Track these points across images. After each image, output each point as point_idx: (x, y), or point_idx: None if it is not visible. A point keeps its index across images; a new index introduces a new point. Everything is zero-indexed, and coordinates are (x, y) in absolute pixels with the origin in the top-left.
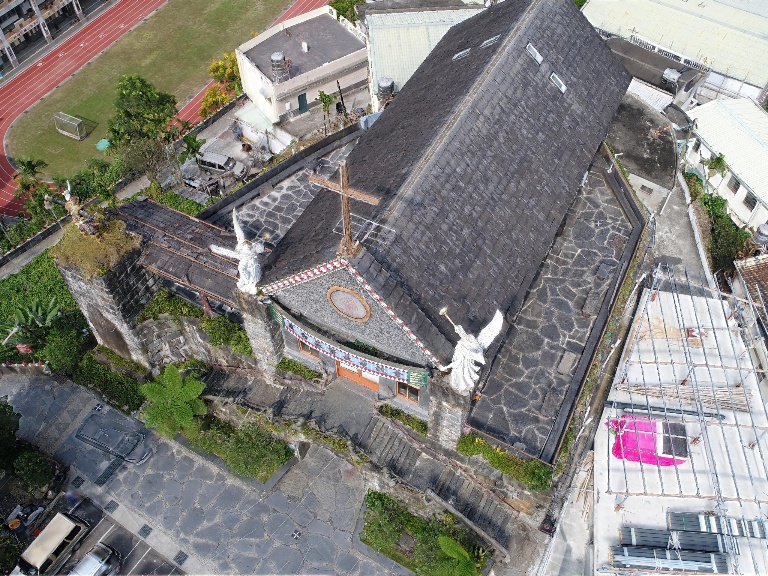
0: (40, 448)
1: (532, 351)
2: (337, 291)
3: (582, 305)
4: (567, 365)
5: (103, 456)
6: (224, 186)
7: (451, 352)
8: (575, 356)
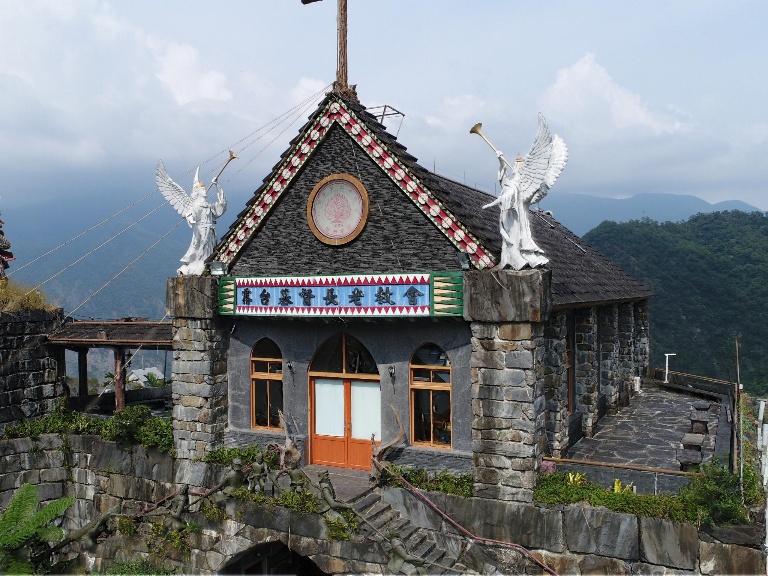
0: None
1: (631, 450)
2: (322, 189)
3: (688, 431)
4: (695, 438)
5: None
6: None
7: (496, 243)
8: (703, 435)
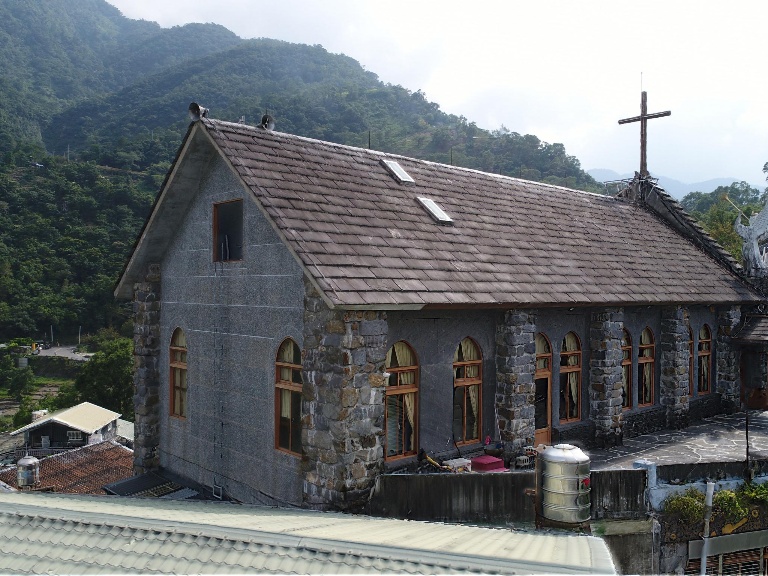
0: None
1: None
2: None
3: None
4: None
5: None
6: None
7: None
8: None
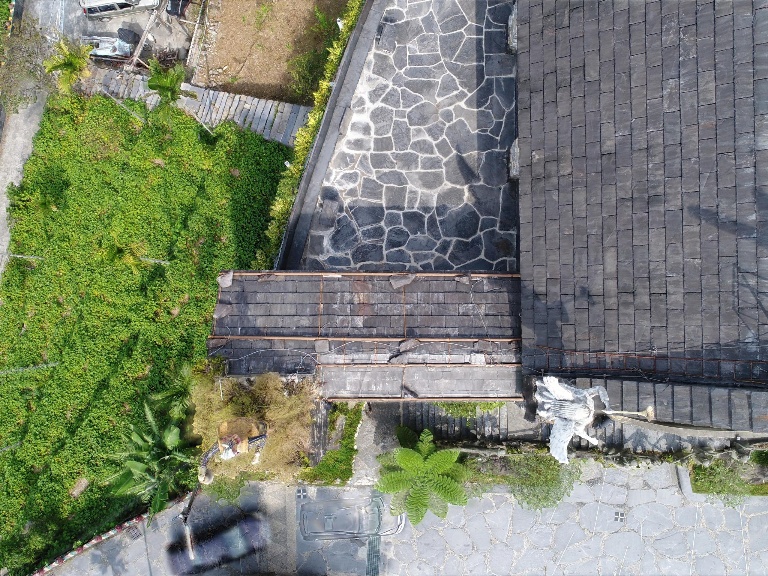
0: (275, 572)
1: None
2: None
3: None
4: None
5: (353, 544)
6: (153, 39)
7: None
8: None
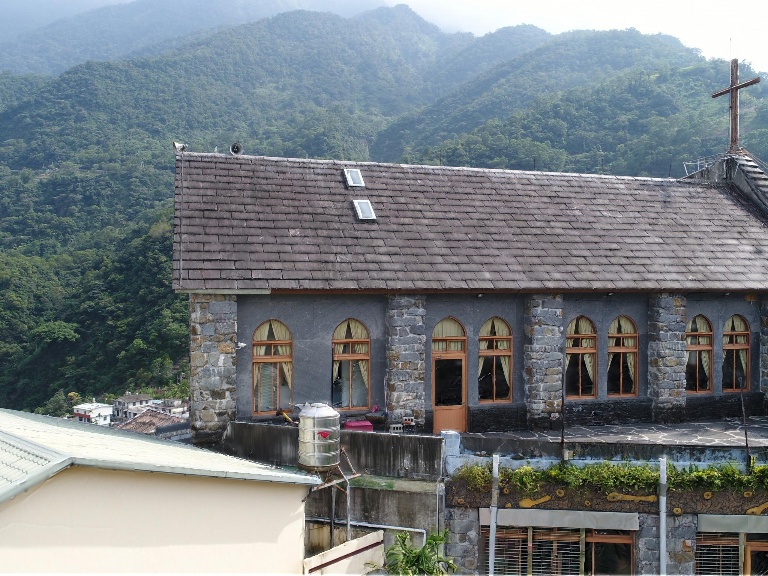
0: None
1: None
2: None
3: None
4: None
5: None
6: None
7: None
8: None
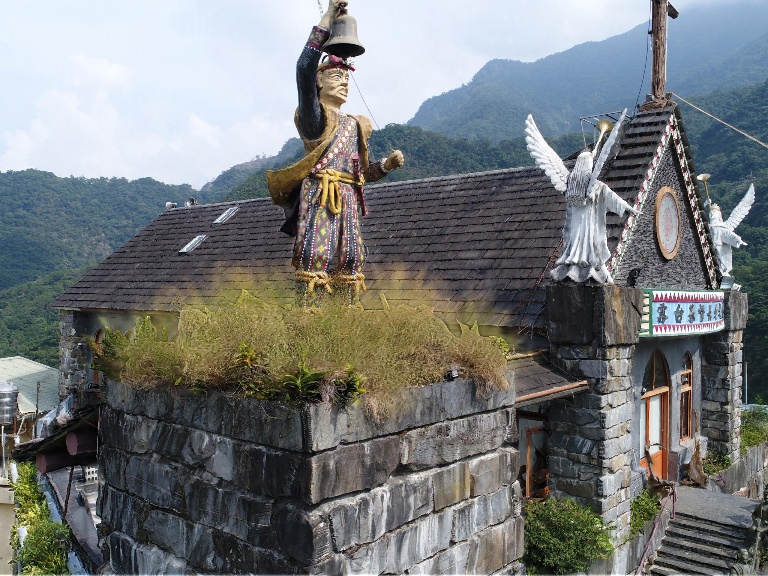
0: None
1: None
2: (662, 199)
3: None
4: None
5: None
6: None
7: None
8: None
